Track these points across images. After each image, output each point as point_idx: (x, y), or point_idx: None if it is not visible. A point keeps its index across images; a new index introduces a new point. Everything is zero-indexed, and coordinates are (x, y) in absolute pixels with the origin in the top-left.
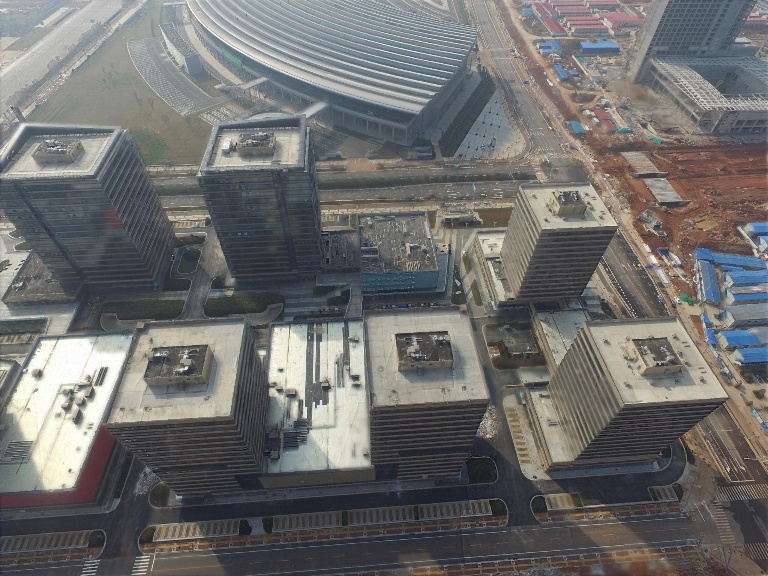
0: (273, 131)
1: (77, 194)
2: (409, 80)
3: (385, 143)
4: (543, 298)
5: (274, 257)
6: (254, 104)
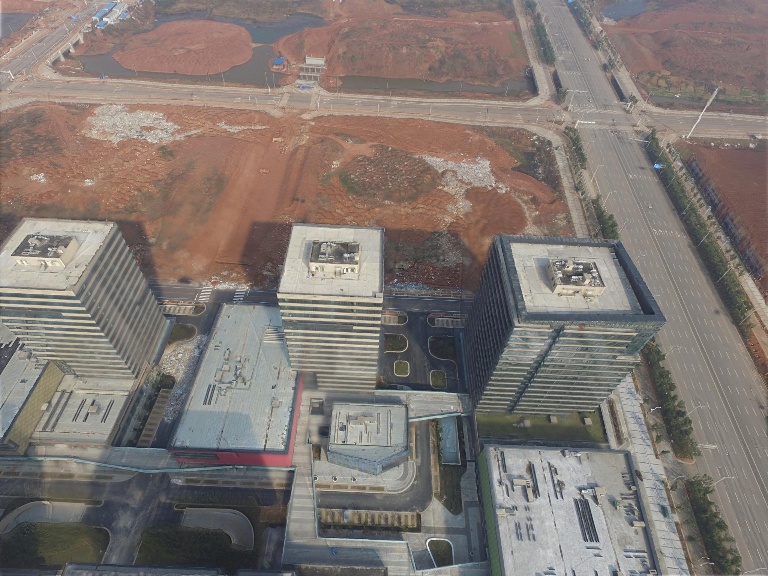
0: None
1: None
2: None
3: None
4: None
5: None
6: None
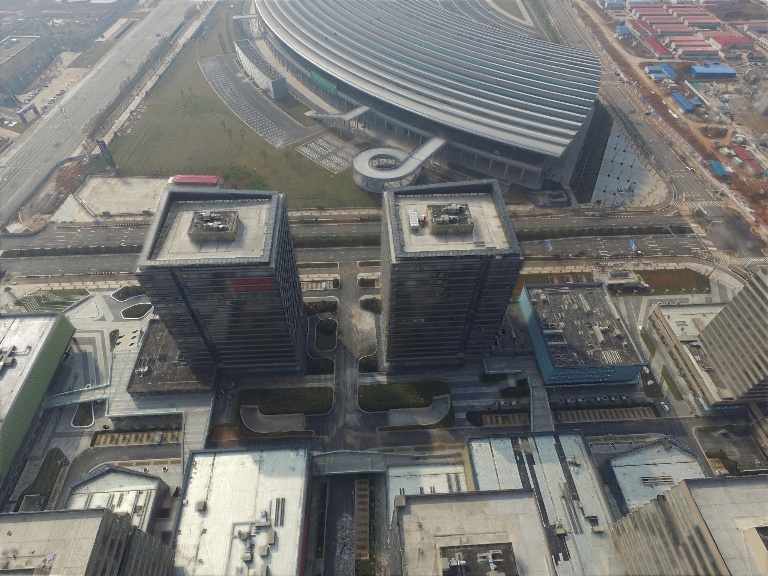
0: (457, 198)
1: (243, 282)
2: (543, 116)
3: (511, 185)
4: (767, 398)
5: (443, 342)
6: (353, 135)
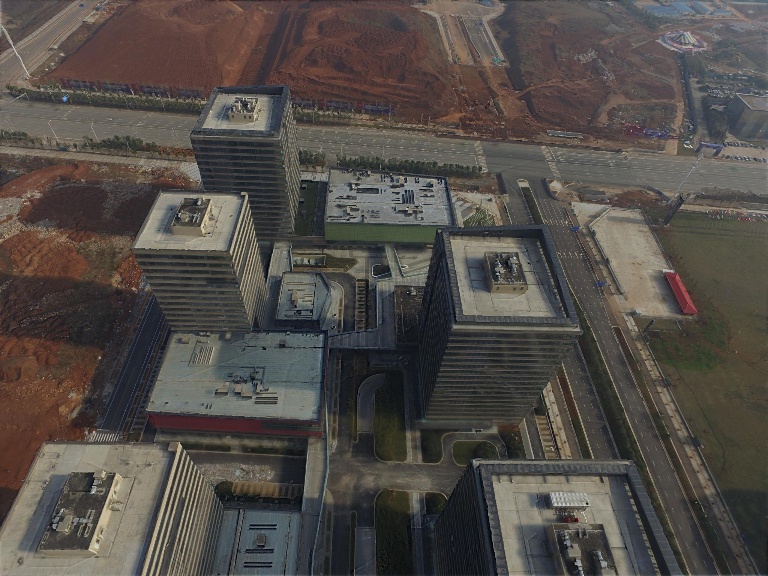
0: None
1: None
2: None
3: None
4: None
5: None
6: None
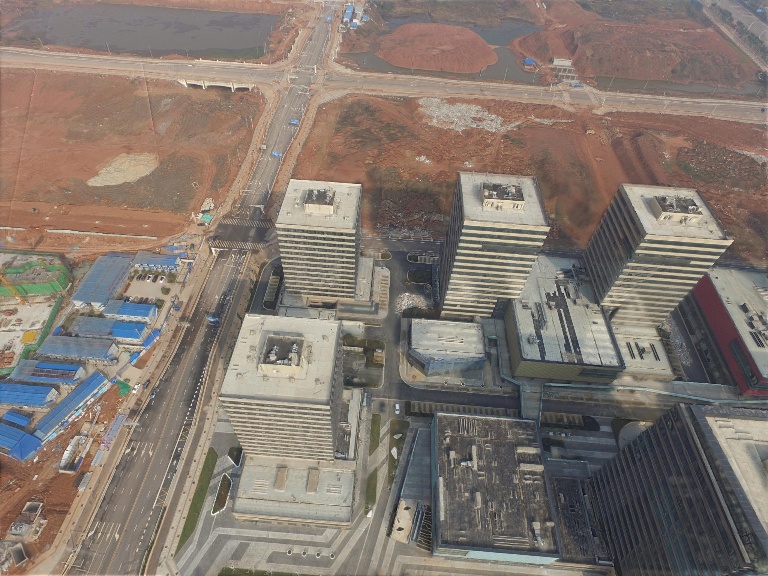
0: None
1: None
2: None
3: None
4: None
5: None
6: None
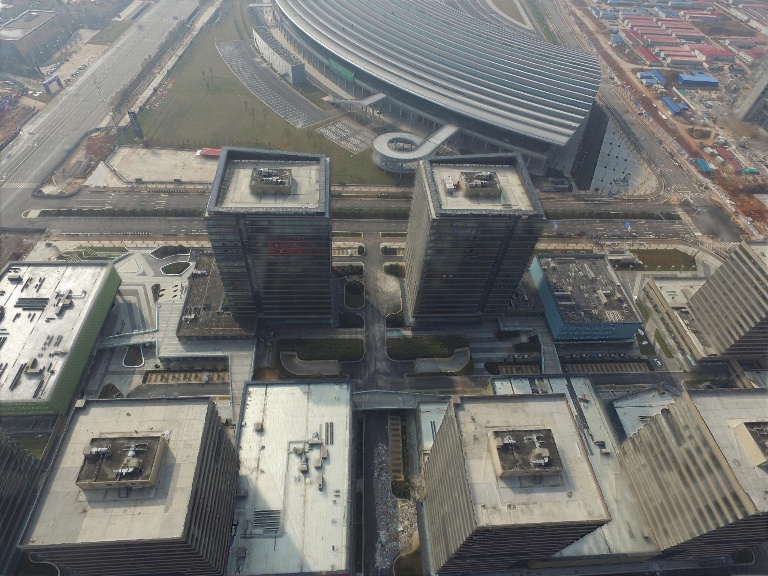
0: (485, 168)
1: (299, 230)
2: (549, 109)
3: None
4: (745, 356)
5: (466, 299)
6: (370, 120)
